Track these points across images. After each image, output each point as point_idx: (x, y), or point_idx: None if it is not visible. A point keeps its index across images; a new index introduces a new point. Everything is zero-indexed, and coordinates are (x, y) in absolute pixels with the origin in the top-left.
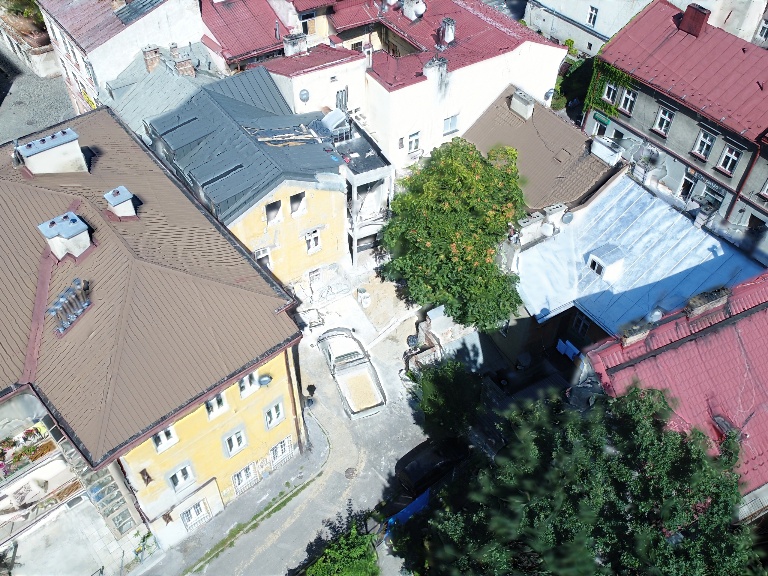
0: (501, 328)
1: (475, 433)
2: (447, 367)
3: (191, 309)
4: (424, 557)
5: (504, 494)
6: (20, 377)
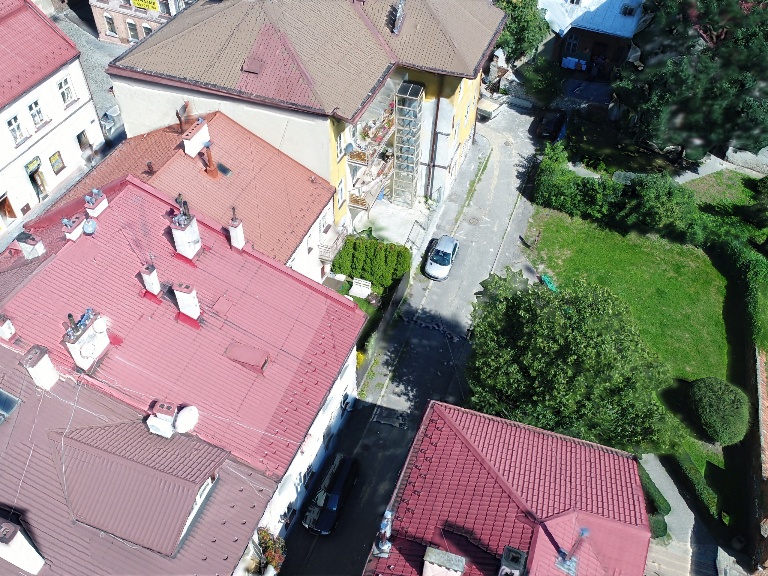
0: (530, 60)
1: (566, 97)
2: (539, 61)
3: (456, 6)
4: (583, 154)
5: (670, 22)
6: (390, 60)
